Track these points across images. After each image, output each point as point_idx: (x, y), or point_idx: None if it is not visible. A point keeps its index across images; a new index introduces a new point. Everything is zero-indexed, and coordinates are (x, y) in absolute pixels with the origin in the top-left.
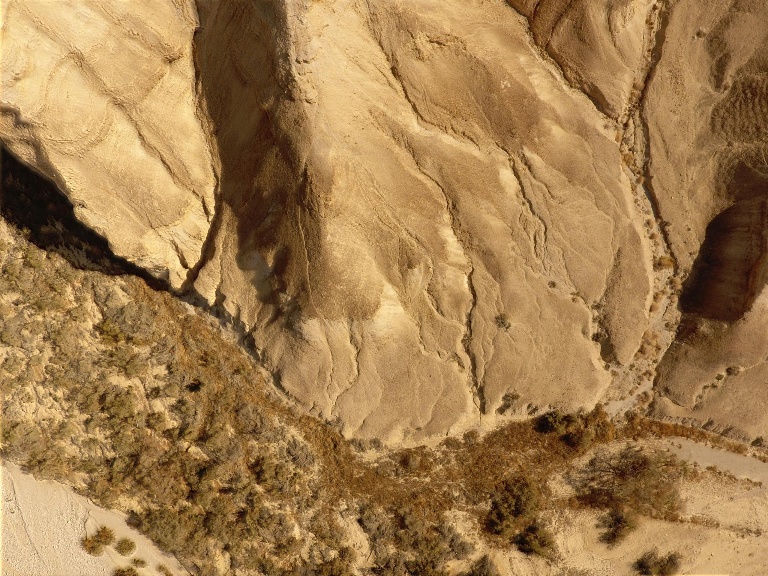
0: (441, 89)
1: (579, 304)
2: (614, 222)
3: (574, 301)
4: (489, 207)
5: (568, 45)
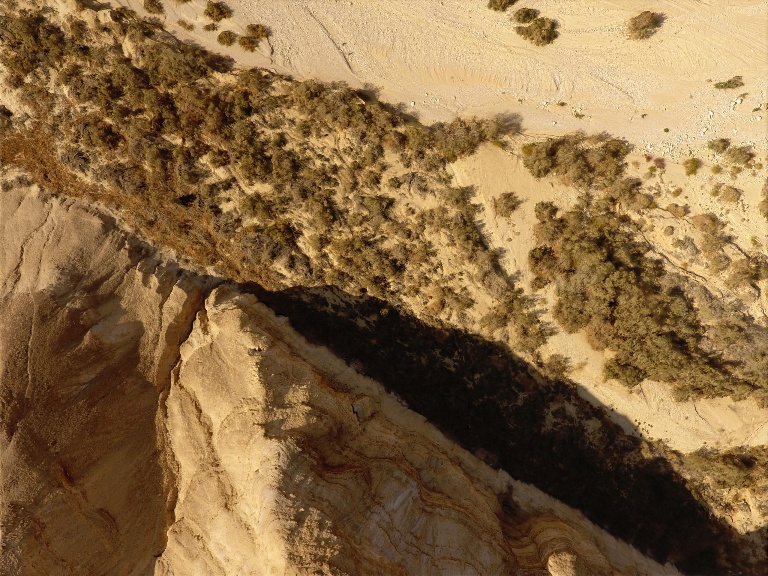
0: None
1: None
2: None
3: None
4: None
5: None
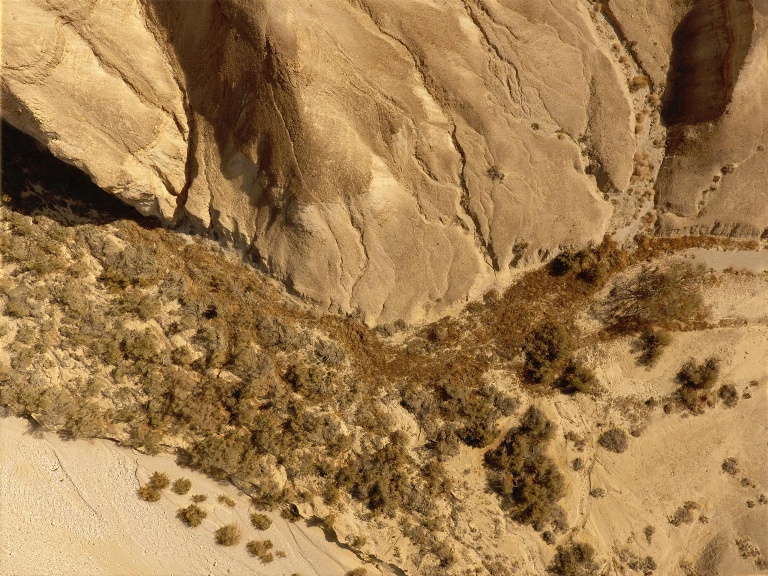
0: None
1: (566, 140)
2: (581, 51)
3: (560, 138)
4: (457, 58)
5: None
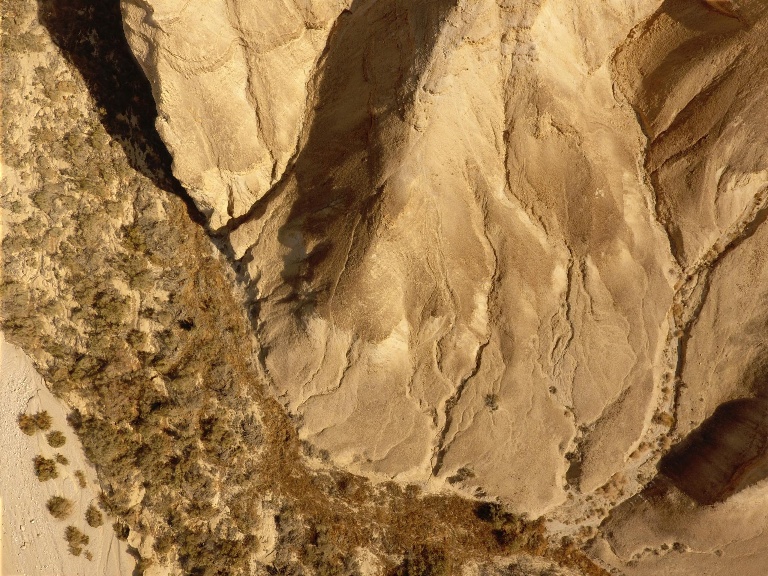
0: (540, 170)
1: (569, 419)
2: (637, 361)
3: (566, 414)
4: (531, 294)
5: (673, 181)
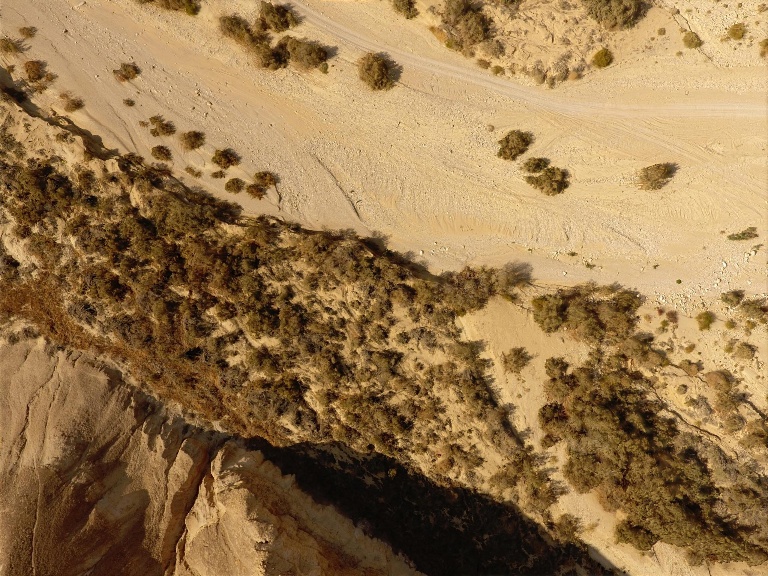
0: None
1: None
2: None
3: None
4: None
5: None
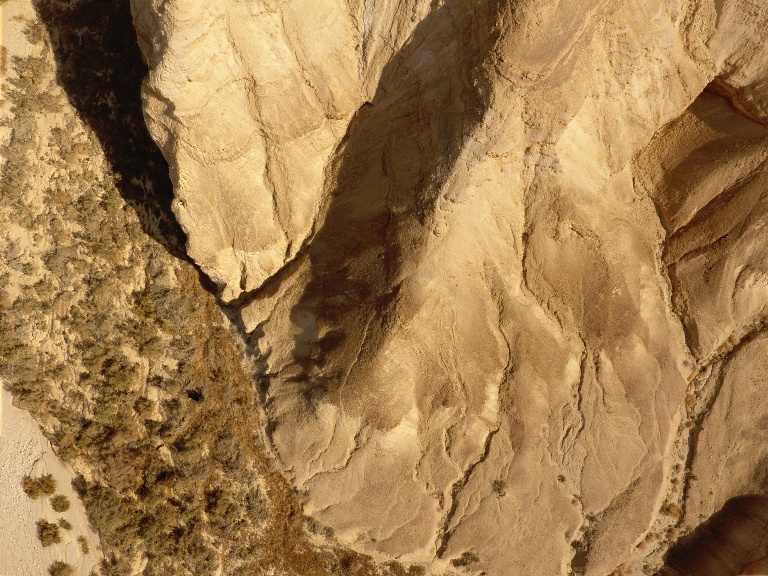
0: (557, 268)
1: (576, 508)
2: (647, 452)
3: (573, 503)
4: (543, 386)
5: (691, 275)
